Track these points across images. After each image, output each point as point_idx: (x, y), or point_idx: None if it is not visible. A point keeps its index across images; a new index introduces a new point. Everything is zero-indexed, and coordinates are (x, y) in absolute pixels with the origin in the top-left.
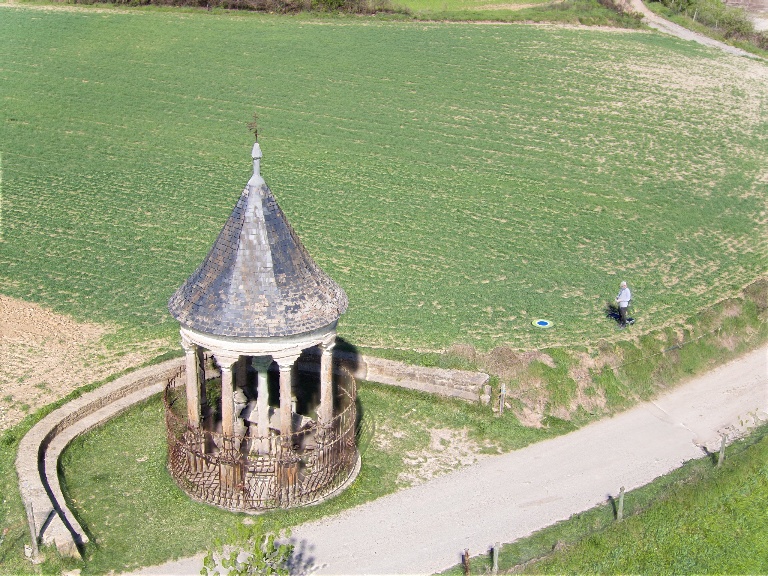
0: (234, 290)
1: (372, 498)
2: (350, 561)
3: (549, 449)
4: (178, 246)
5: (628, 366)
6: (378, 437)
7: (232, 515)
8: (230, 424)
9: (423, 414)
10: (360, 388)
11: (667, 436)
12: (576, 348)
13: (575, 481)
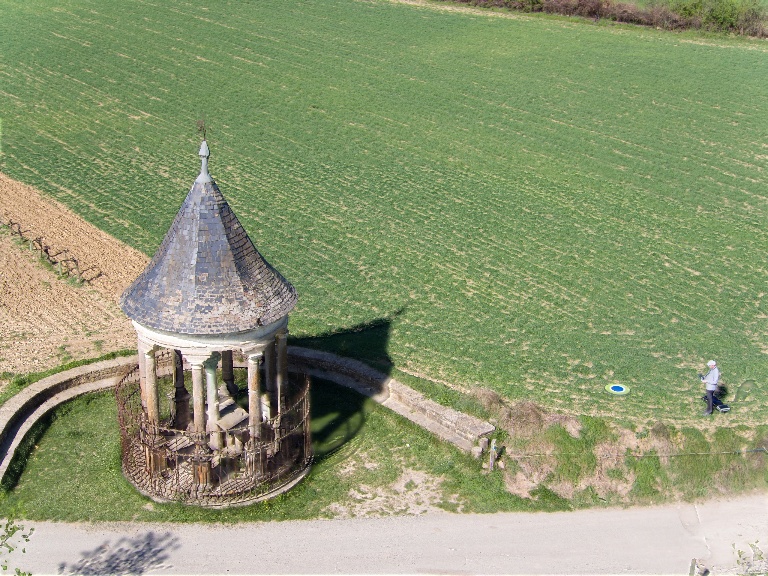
0: (159, 280)
1: (280, 518)
2: (196, 570)
3: (515, 522)
4: (338, 242)
5: (683, 457)
6: (348, 462)
7: (140, 496)
8: (152, 409)
9: (412, 452)
10: (374, 411)
11: (670, 546)
12: (621, 422)
13: (507, 563)
